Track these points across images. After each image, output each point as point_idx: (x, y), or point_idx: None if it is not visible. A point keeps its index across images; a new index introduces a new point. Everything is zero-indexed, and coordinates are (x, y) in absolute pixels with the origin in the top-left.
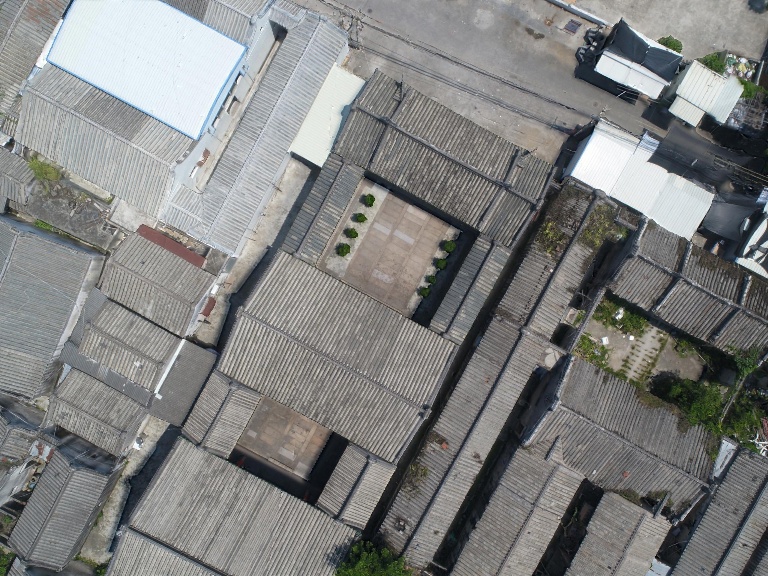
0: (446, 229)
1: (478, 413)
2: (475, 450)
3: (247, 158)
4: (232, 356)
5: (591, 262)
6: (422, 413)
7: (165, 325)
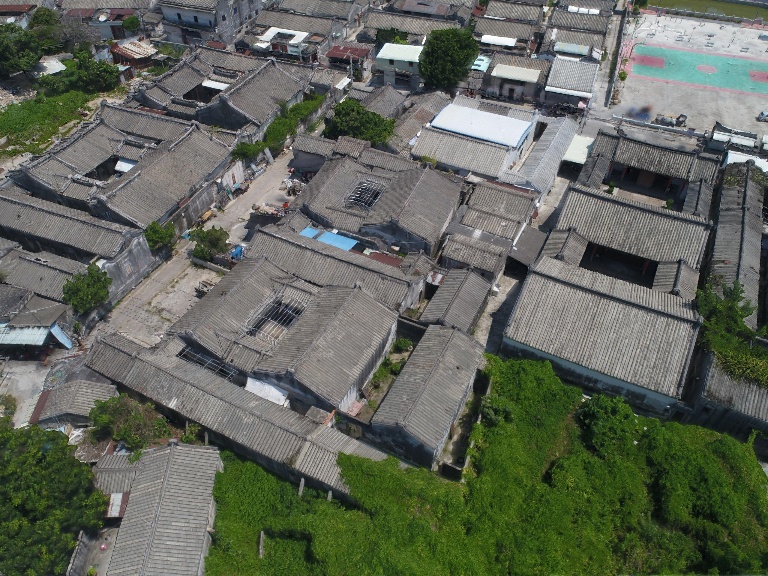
0: (661, 202)
1: (740, 244)
2: (749, 265)
3: (543, 156)
4: (565, 219)
5: (763, 192)
6: (707, 225)
7: None
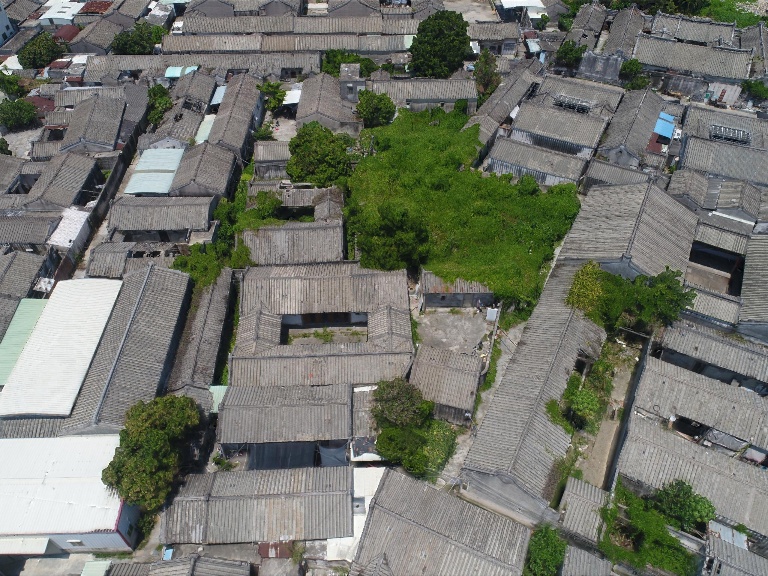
0: None
1: None
2: None
3: None
4: (767, 237)
5: None
6: None
7: (760, 215)
